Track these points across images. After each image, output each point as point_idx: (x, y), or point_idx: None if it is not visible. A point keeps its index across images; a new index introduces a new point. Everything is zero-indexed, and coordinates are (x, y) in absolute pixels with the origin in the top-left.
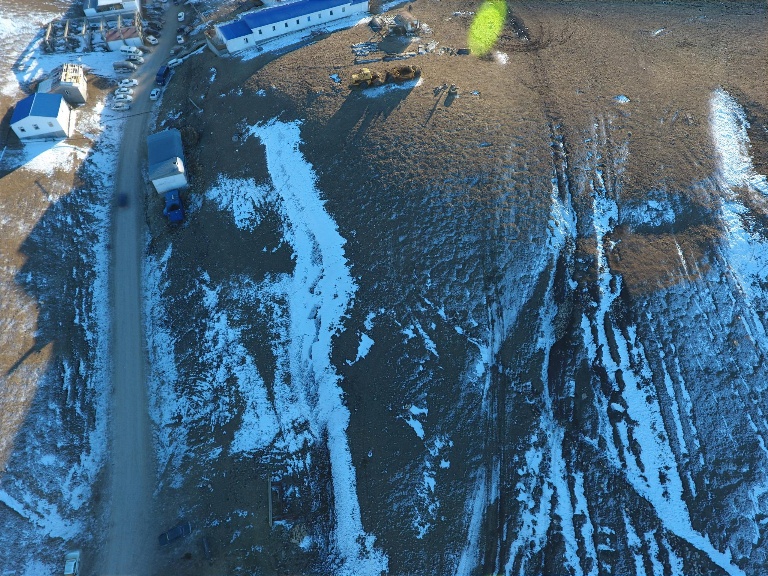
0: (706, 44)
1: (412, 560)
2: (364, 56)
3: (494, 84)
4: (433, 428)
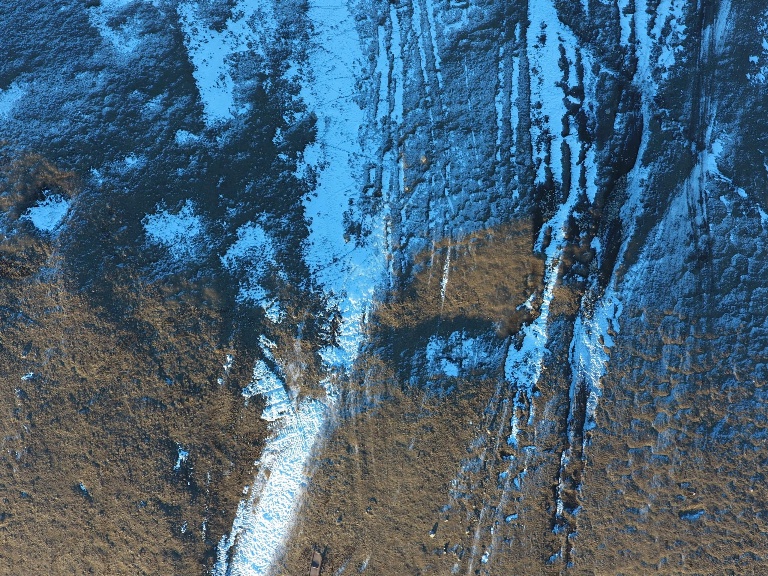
0: None
1: None
2: None
3: None
4: (767, 91)
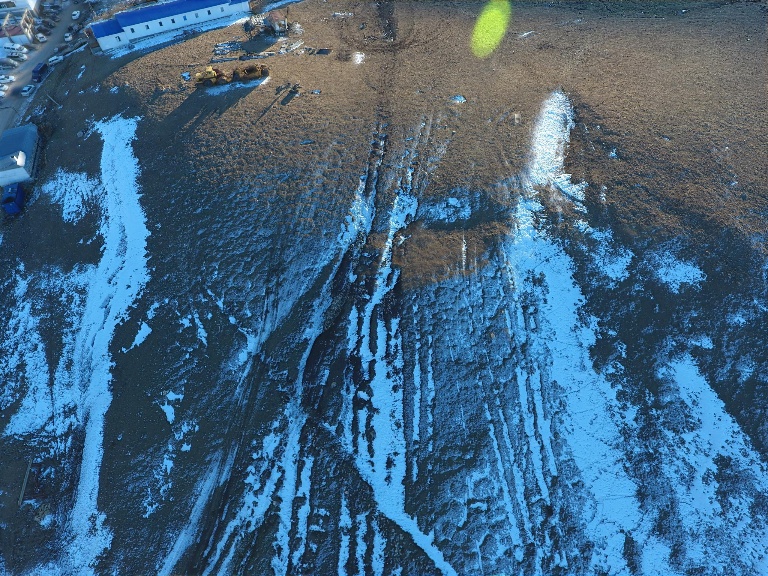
0: (567, 46)
1: (134, 538)
2: (223, 55)
3: (338, 83)
4: (184, 413)
